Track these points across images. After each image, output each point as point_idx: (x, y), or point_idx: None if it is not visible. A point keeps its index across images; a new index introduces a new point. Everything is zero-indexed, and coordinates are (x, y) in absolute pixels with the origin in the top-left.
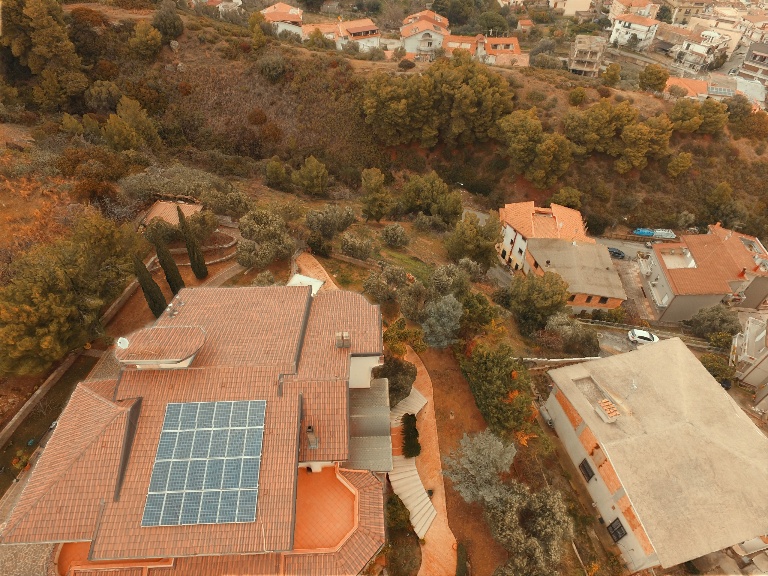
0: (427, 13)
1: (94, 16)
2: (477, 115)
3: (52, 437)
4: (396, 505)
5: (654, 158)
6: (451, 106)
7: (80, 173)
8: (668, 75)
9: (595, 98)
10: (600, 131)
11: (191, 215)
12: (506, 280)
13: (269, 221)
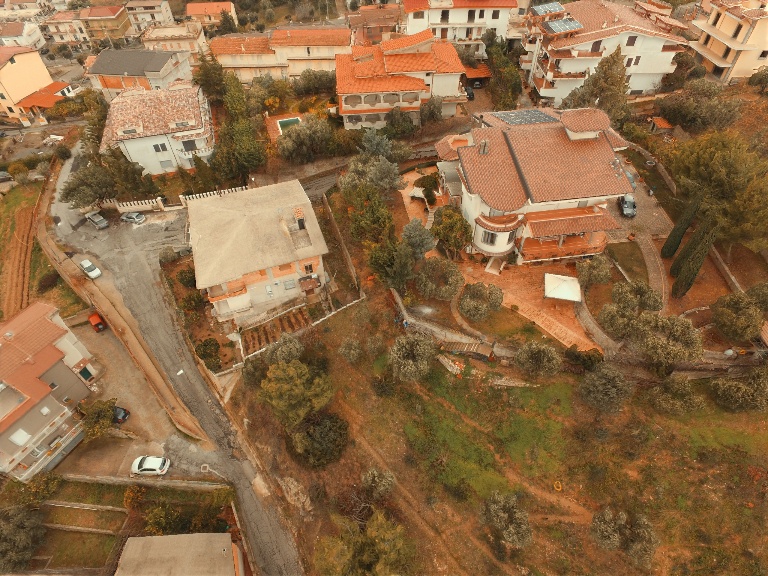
0: None
1: None
2: None
3: None
4: (431, 180)
5: None
6: None
7: None
8: None
9: None
10: None
11: None
12: None
13: None
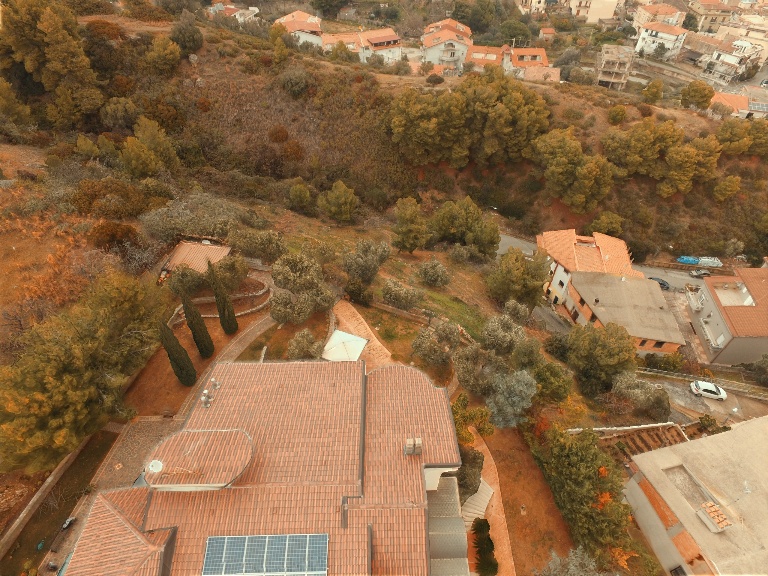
0: (449, 22)
1: (110, 29)
2: (511, 134)
3: (67, 572)
4: None
5: (699, 181)
6: (483, 125)
7: (97, 210)
8: (713, 92)
9: (635, 116)
10: (643, 153)
11: (219, 260)
12: (548, 317)
13: (305, 267)
